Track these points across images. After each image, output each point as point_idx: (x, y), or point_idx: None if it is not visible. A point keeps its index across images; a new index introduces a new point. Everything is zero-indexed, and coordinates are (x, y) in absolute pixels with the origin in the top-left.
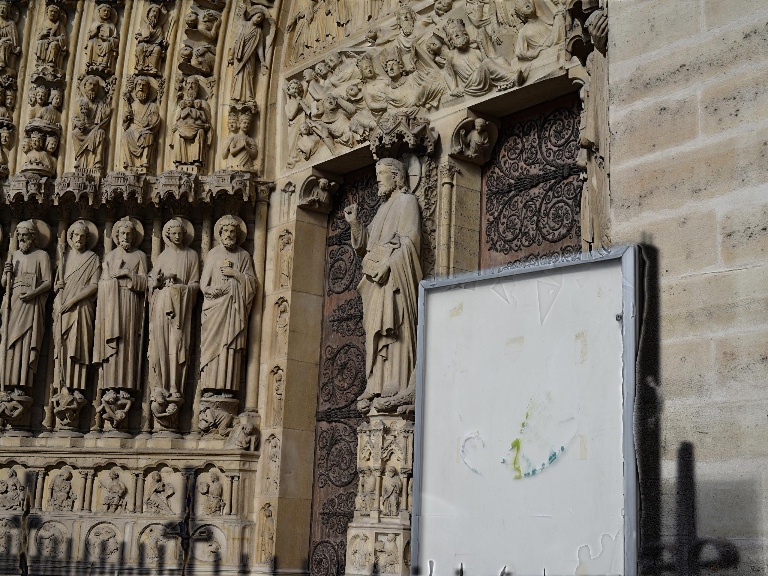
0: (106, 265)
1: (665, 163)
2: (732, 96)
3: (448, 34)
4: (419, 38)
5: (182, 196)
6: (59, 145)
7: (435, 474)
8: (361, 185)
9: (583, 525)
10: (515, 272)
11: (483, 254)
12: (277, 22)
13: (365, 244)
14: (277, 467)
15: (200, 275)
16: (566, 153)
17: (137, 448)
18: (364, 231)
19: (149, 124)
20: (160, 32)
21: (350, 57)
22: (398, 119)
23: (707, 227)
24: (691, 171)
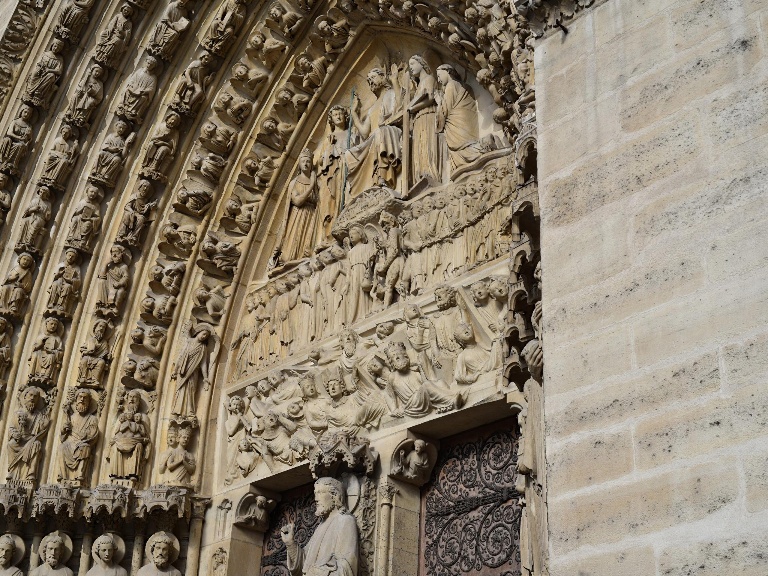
0: None
1: (602, 496)
2: (664, 432)
3: (389, 356)
4: (361, 359)
5: (115, 511)
6: None
7: None
8: (299, 503)
9: None
10: None
11: None
12: (222, 339)
13: (301, 566)
14: None
15: None
16: (505, 476)
17: None
18: (300, 552)
19: (87, 437)
20: (105, 346)
21: (292, 375)
22: (338, 438)
23: (645, 563)
24: (627, 505)
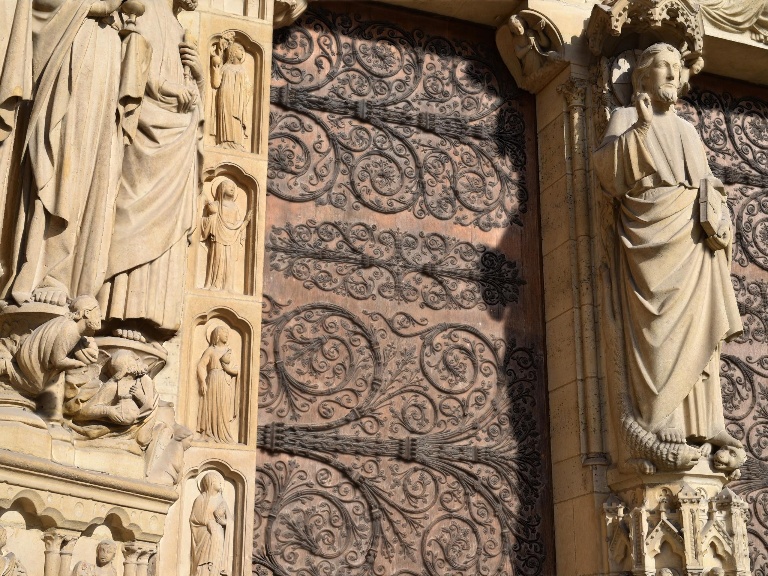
0: None
1: None
2: None
3: None
4: None
5: None
6: None
7: None
8: (344, 25)
9: None
10: None
11: None
12: None
13: None
14: (229, 539)
15: None
16: None
17: None
18: None
19: None
20: None
21: None
22: None
23: None
24: None
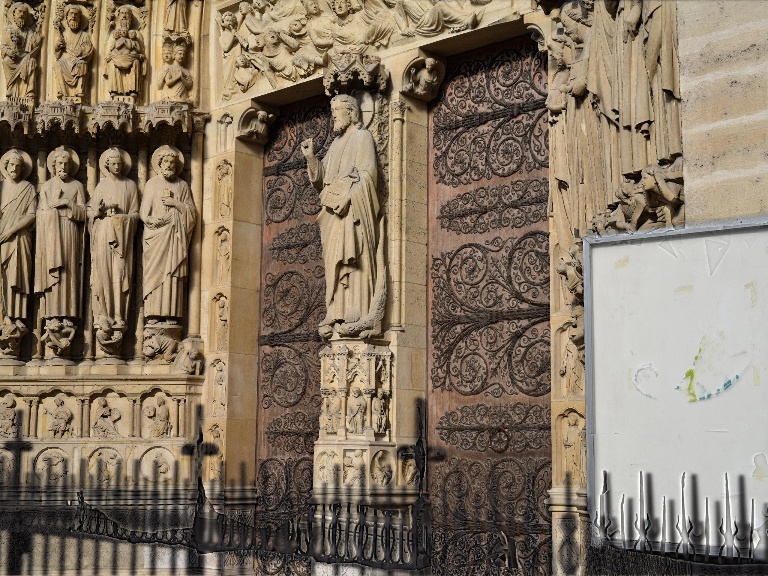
0: (44, 195)
1: (737, 129)
2: None
3: None
4: None
5: None
6: None
7: (607, 399)
8: (299, 117)
9: (759, 438)
10: (683, 232)
11: (431, 187)
12: None
13: (321, 177)
14: (224, 390)
15: (139, 205)
16: (515, 93)
17: (82, 375)
18: (320, 165)
19: (82, 53)
20: None
21: None
22: (352, 57)
23: None
24: (763, 137)
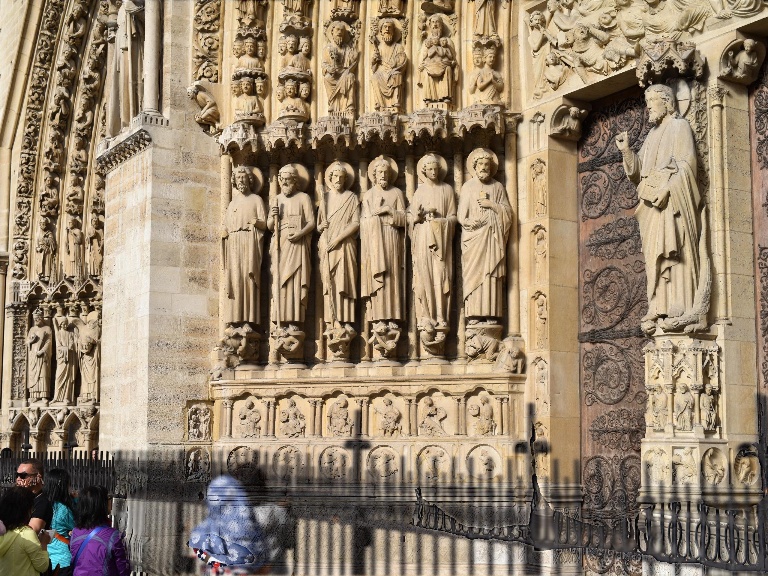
0: (367, 203)
1: None
2: None
3: None
4: None
5: None
6: (311, 91)
7: None
8: (612, 111)
9: None
10: None
11: (755, 173)
12: None
13: (638, 170)
14: (546, 388)
15: (456, 208)
16: None
17: (408, 375)
18: (636, 158)
19: (397, 65)
20: None
21: None
22: (665, 45)
23: None
24: None
